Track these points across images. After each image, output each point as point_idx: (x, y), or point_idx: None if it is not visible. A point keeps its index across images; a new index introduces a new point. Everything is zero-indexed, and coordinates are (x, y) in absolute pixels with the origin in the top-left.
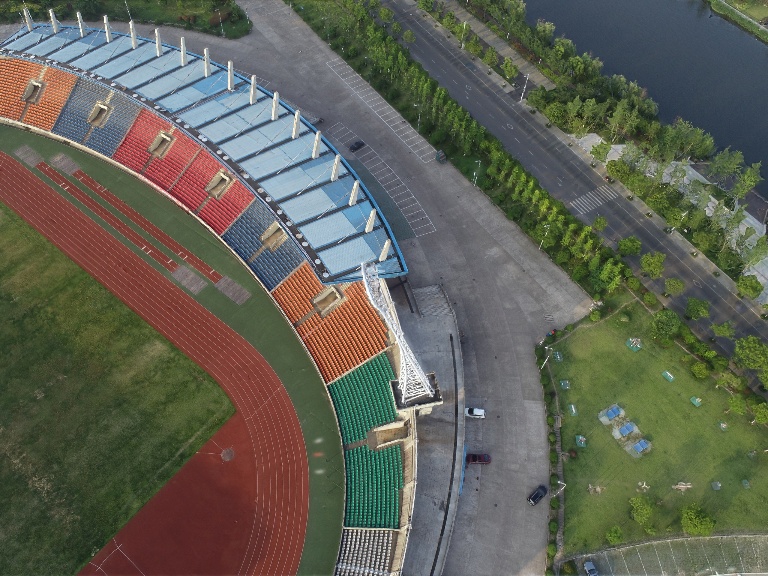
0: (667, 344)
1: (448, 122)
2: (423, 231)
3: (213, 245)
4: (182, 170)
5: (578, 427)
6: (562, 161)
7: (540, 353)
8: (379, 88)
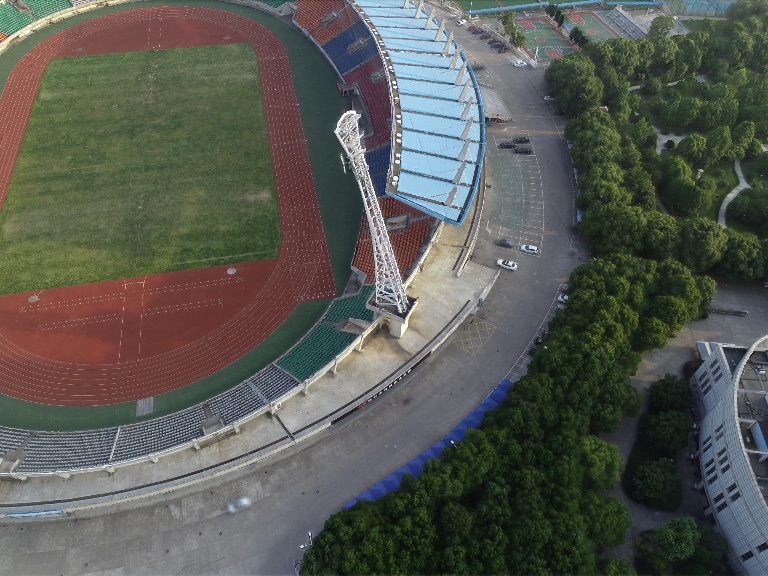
0: None
1: None
2: None
3: None
4: None
5: None
6: None
7: None
8: None
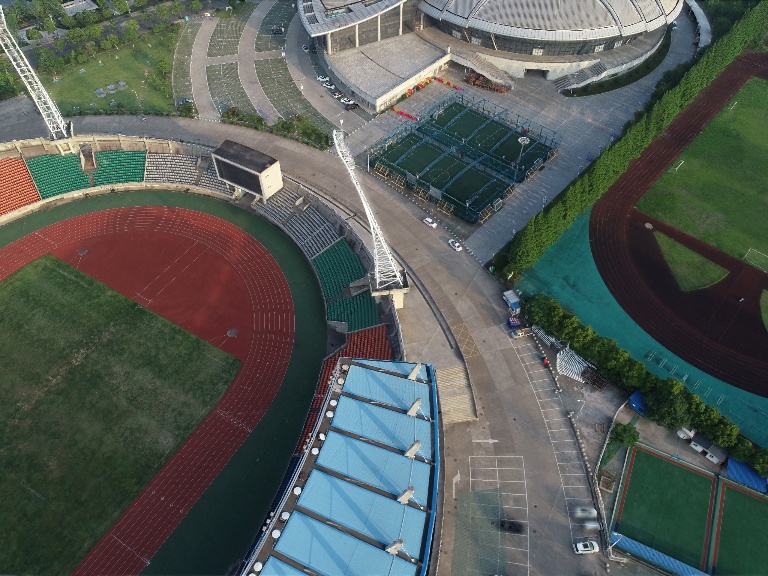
0: (62, 67)
1: None
2: None
3: None
4: None
5: (105, 105)
6: None
7: None
8: None
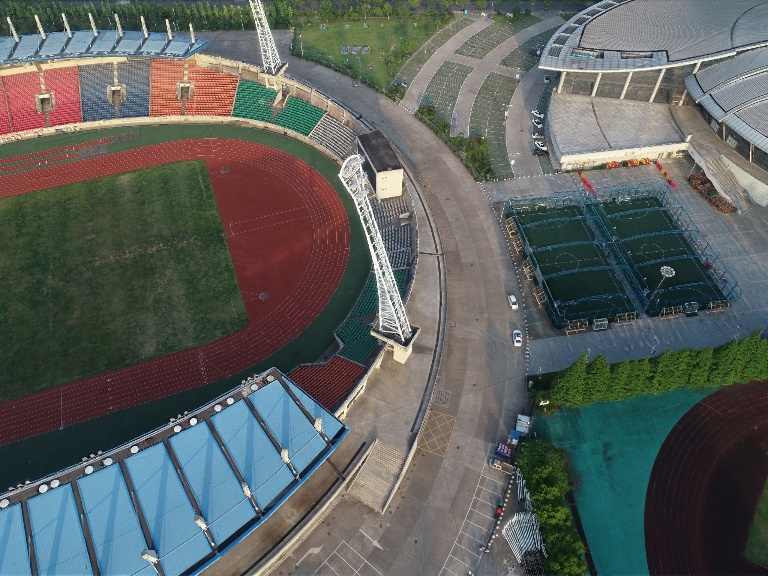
0: (334, 18)
1: (129, 12)
2: None
3: (81, 135)
4: (7, 116)
5: (340, 61)
6: (205, 1)
7: (296, 53)
8: (60, 31)
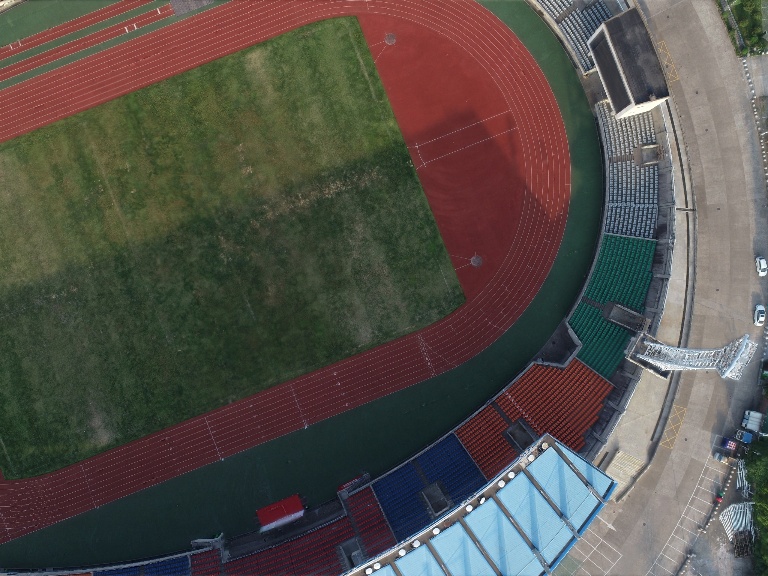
0: None
1: None
2: None
3: None
4: None
5: None
6: None
7: None
8: None
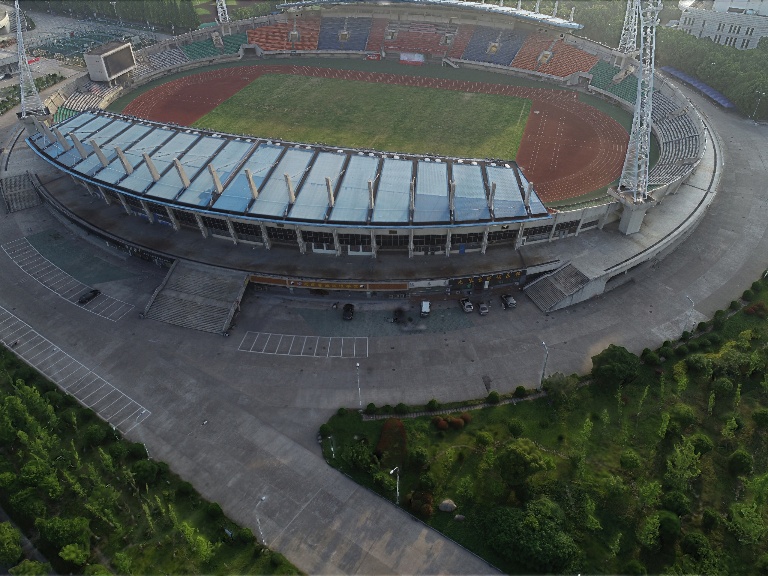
0: None
1: None
2: (16, 242)
3: None
4: None
5: None
6: None
7: None
8: None
